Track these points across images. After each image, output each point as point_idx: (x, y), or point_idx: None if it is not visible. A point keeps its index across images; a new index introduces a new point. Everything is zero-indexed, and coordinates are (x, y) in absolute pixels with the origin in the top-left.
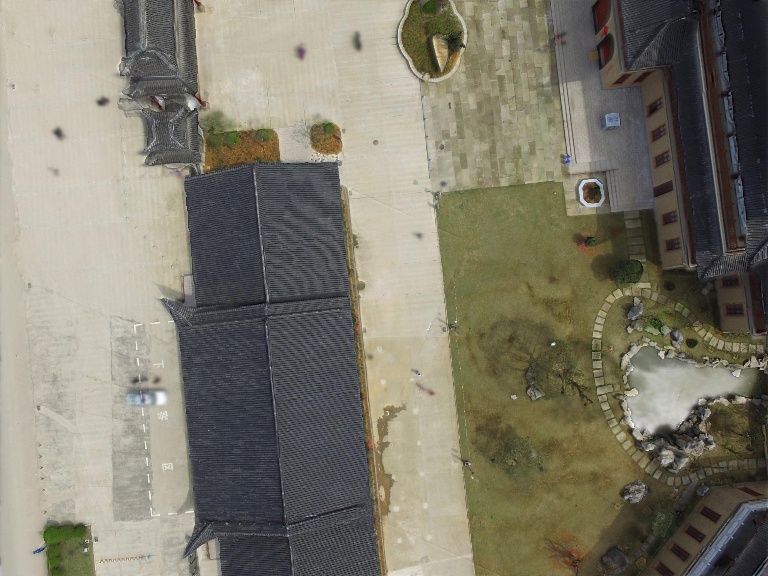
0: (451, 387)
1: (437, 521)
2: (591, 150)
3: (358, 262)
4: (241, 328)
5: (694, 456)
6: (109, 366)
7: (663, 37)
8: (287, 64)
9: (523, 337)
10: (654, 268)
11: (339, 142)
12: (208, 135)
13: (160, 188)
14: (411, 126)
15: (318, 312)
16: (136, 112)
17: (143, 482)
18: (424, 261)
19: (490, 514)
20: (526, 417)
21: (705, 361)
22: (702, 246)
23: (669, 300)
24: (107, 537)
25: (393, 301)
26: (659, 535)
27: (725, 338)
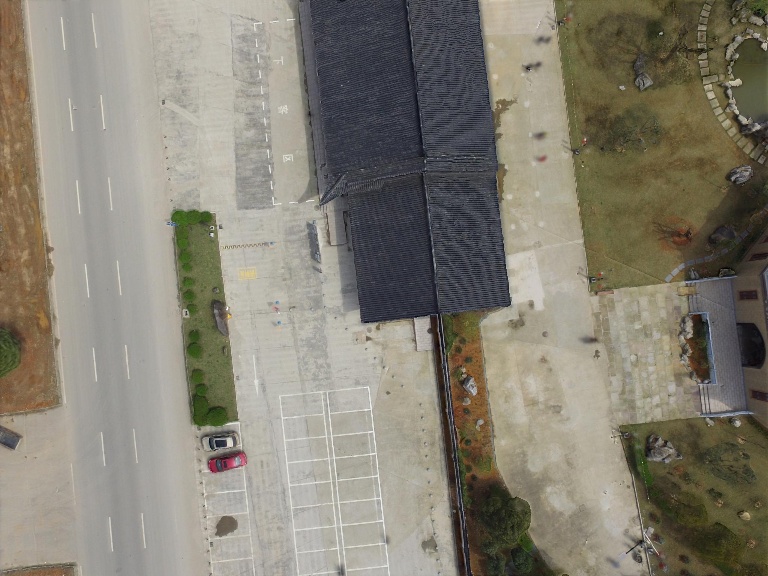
0: (560, 82)
1: (549, 208)
2: None
3: None
4: None
5: None
6: (230, 62)
7: None
8: None
9: (630, 31)
10: None
11: None
12: None
13: None
14: None
15: None
16: None
17: (265, 172)
18: None
19: (600, 201)
20: (634, 107)
21: None
22: None
23: None
24: (231, 224)
25: None
26: (764, 217)
27: None
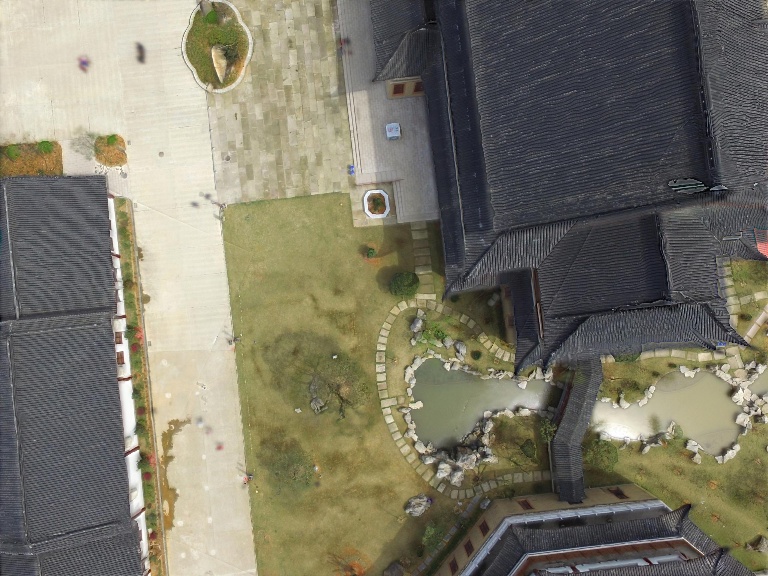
0: (237, 401)
1: (221, 536)
2: (376, 160)
3: (143, 275)
4: None
5: (478, 469)
6: None
7: (408, 48)
8: (72, 75)
9: (307, 350)
10: (440, 279)
11: (123, 154)
12: None
13: None
14: (197, 137)
15: (71, 328)
16: None
17: None
18: (210, 274)
19: (274, 528)
20: (310, 430)
21: (490, 373)
22: (450, 259)
23: (454, 312)
24: None
25: (178, 314)
26: (443, 549)
27: (511, 350)
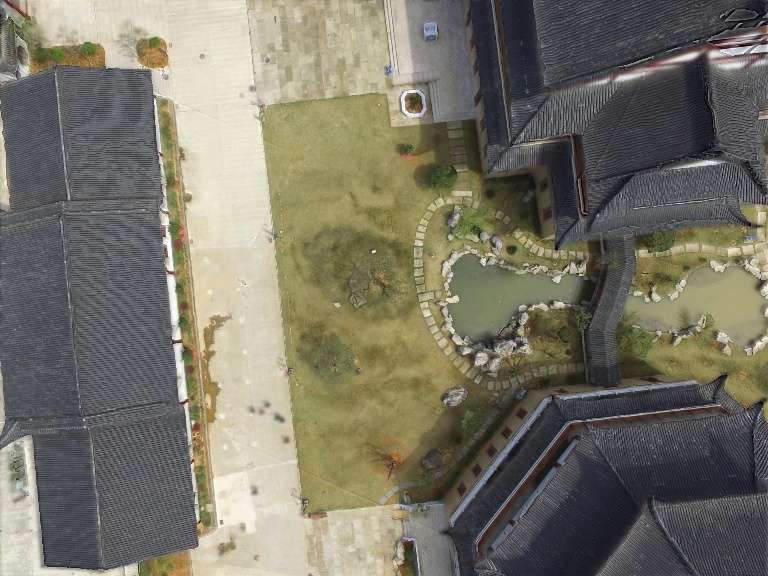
0: (277, 296)
1: (263, 428)
2: (413, 61)
3: (185, 174)
4: (42, 226)
5: (514, 361)
6: None
7: None
8: None
9: (346, 246)
10: (476, 177)
11: (165, 55)
12: (34, 49)
13: None
14: (237, 40)
15: (121, 211)
16: None
17: None
18: (250, 173)
19: (314, 420)
20: (349, 325)
21: (525, 268)
22: (492, 140)
23: (490, 208)
24: None
25: (219, 212)
26: (479, 439)
27: (545, 245)
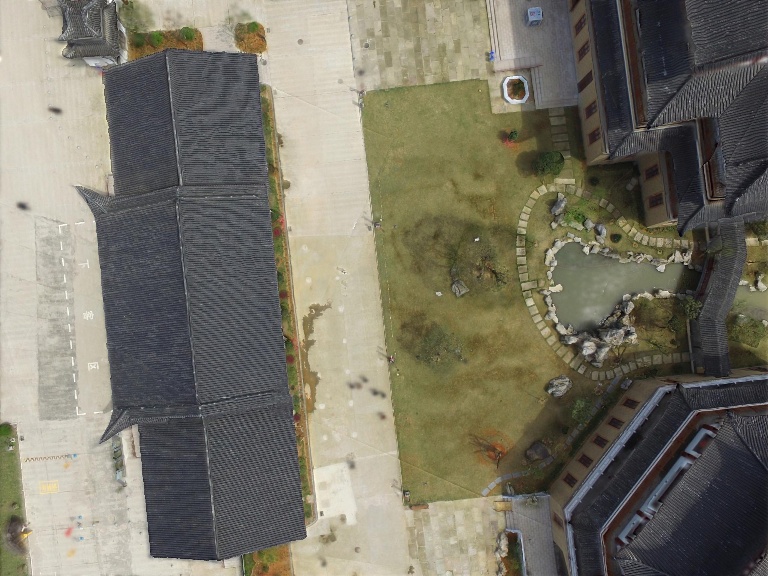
0: (377, 285)
1: (363, 418)
2: (515, 47)
3: (283, 161)
4: (154, 212)
5: (618, 351)
6: (34, 266)
7: None
8: None
9: (448, 234)
10: (579, 164)
11: (263, 41)
12: (131, 34)
13: (84, 88)
14: (336, 25)
15: (232, 197)
16: (58, 10)
17: (69, 381)
18: (349, 160)
19: (415, 410)
20: (451, 314)
21: (629, 256)
22: (613, 125)
23: (593, 196)
24: (33, 436)
25: (318, 200)
26: (583, 429)
27: (649, 233)
